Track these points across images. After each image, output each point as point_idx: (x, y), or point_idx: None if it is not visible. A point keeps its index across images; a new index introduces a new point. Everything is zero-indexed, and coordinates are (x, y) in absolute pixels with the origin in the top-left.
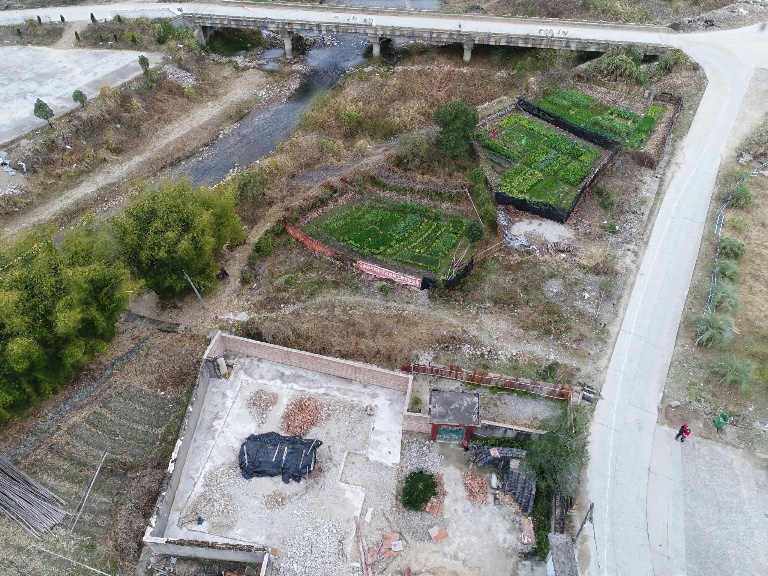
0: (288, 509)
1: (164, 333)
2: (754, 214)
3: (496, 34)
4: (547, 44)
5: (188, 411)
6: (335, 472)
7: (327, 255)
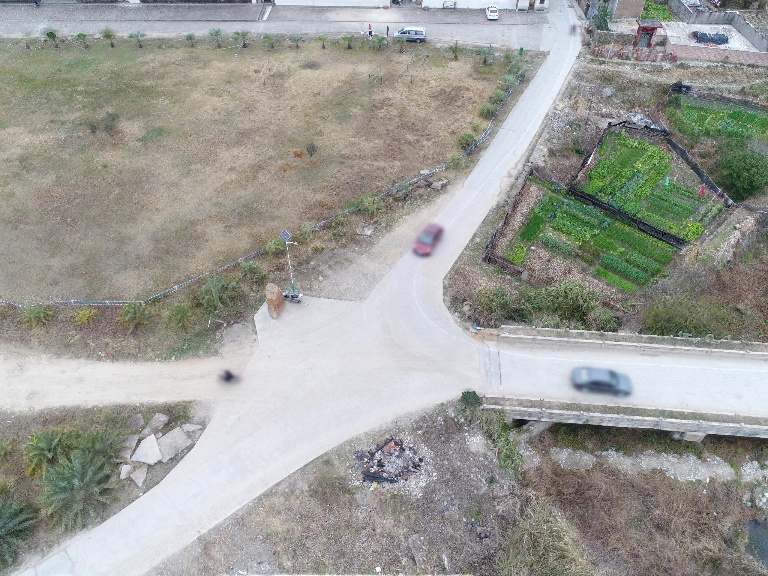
0: None
1: None
2: None
3: None
4: None
5: (760, 32)
6: None
7: None
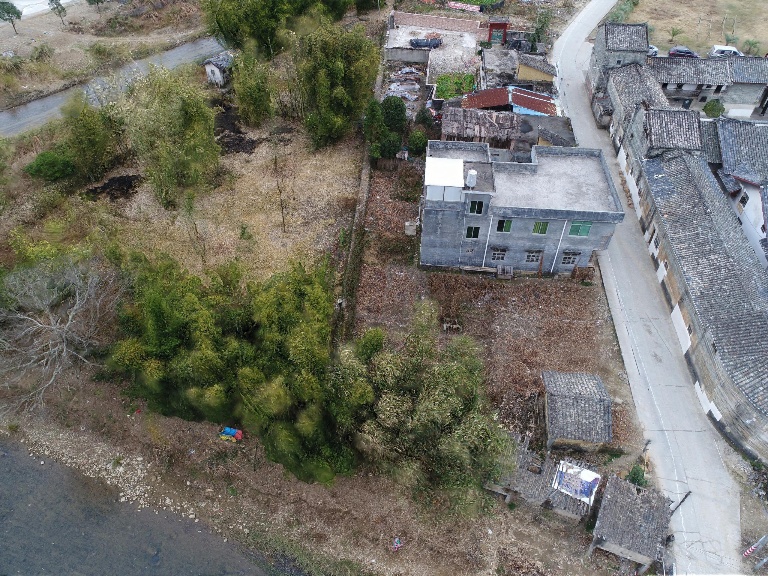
0: (433, 53)
1: (363, 21)
2: None
3: None
4: None
5: (389, 25)
6: (450, 47)
7: (432, 3)
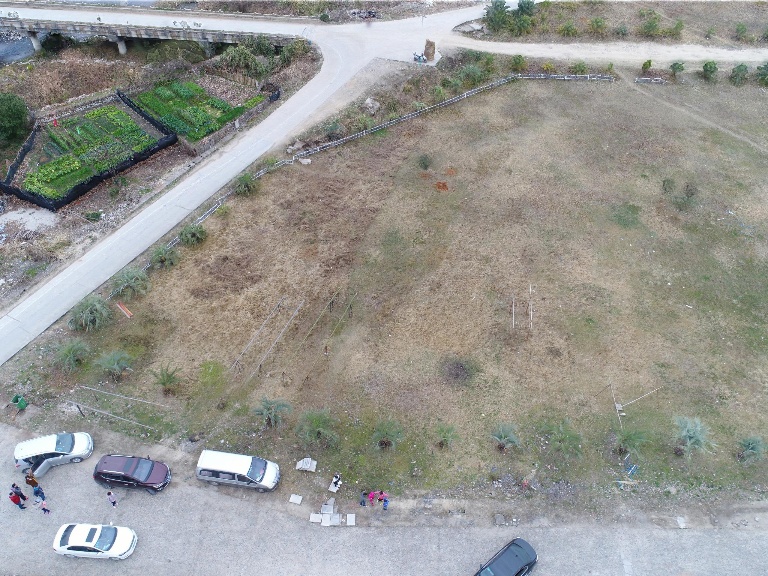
0: None
1: None
2: (256, 201)
3: (135, 27)
4: (185, 36)
5: None
6: None
7: None
